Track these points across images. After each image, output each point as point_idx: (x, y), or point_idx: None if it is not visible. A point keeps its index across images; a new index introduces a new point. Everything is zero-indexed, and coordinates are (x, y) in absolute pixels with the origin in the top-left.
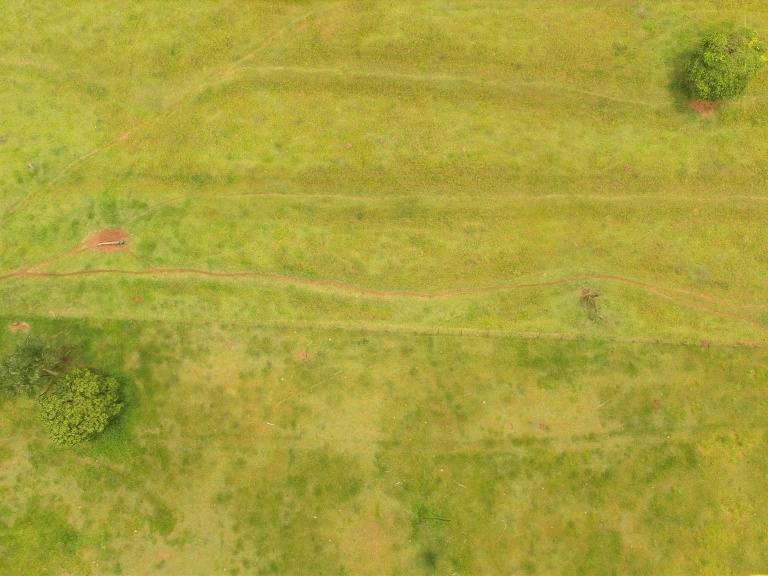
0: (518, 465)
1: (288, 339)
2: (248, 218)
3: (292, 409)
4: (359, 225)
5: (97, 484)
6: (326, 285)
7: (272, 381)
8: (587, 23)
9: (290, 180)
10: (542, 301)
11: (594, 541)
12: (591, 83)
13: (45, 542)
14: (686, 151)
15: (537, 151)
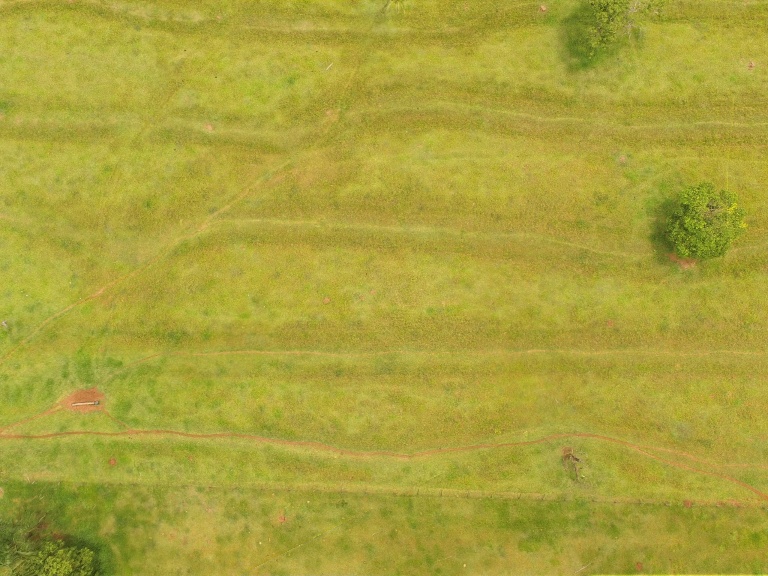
0: None
1: (266, 502)
2: (225, 376)
3: (270, 574)
4: (337, 383)
5: None
6: (304, 445)
7: (250, 545)
8: (568, 171)
9: (268, 336)
10: (523, 460)
11: None
12: (572, 234)
13: None
14: (668, 305)
15: (517, 305)
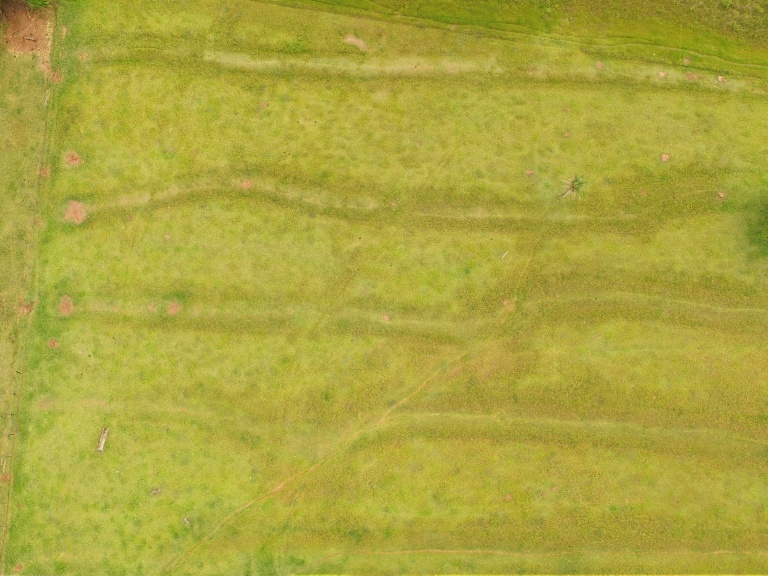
0: None
1: None
2: (407, 575)
3: None
4: None
5: None
6: None
7: None
8: (749, 364)
9: (449, 533)
10: None
11: None
12: (756, 430)
13: None
14: None
15: (703, 504)
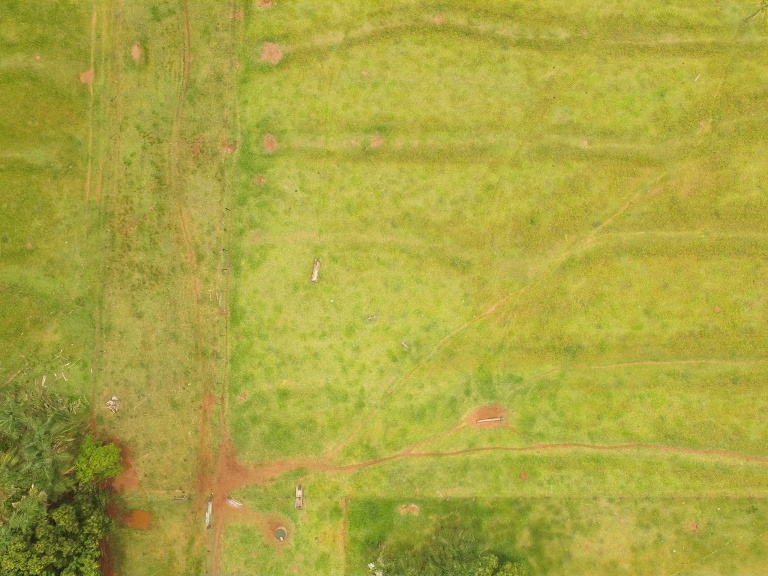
0: None
1: (677, 510)
2: (624, 387)
3: None
4: (736, 390)
5: None
6: (710, 453)
7: (664, 553)
8: None
9: (661, 346)
10: None
11: None
12: None
13: None
14: None
15: None
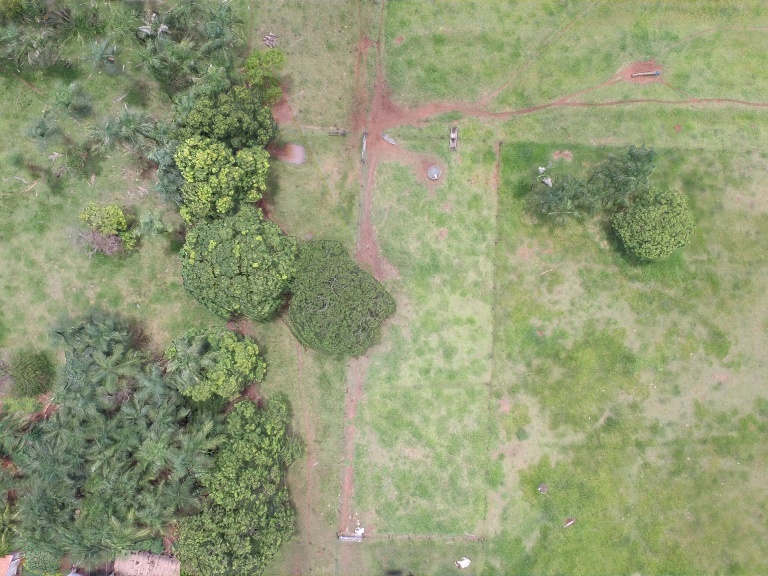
0: None
1: None
2: None
3: None
4: None
5: (650, 308)
6: None
7: None
8: None
9: None
10: None
11: None
12: None
13: (604, 364)
14: None
15: None
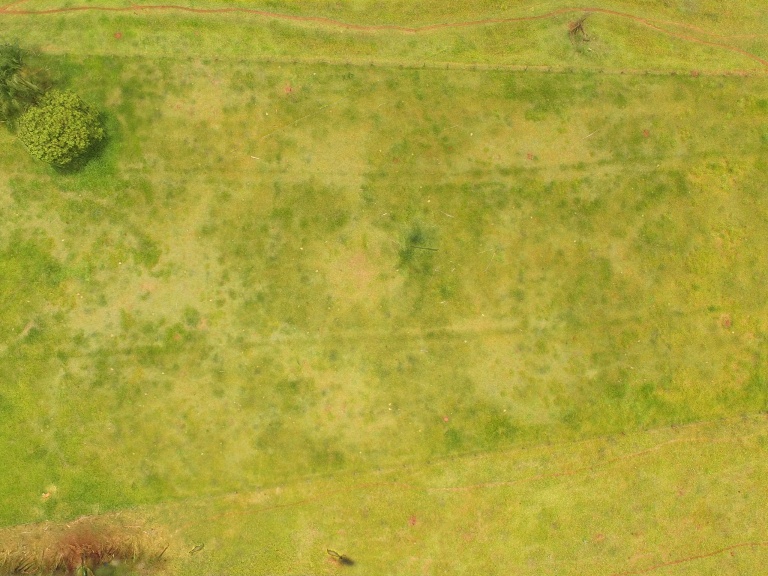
0: (506, 195)
1: (272, 74)
2: None
3: (277, 143)
4: None
5: (80, 218)
6: (310, 20)
7: (256, 116)
8: None
9: None
10: (529, 34)
11: (583, 268)
12: None
13: (28, 274)
14: None
15: None
